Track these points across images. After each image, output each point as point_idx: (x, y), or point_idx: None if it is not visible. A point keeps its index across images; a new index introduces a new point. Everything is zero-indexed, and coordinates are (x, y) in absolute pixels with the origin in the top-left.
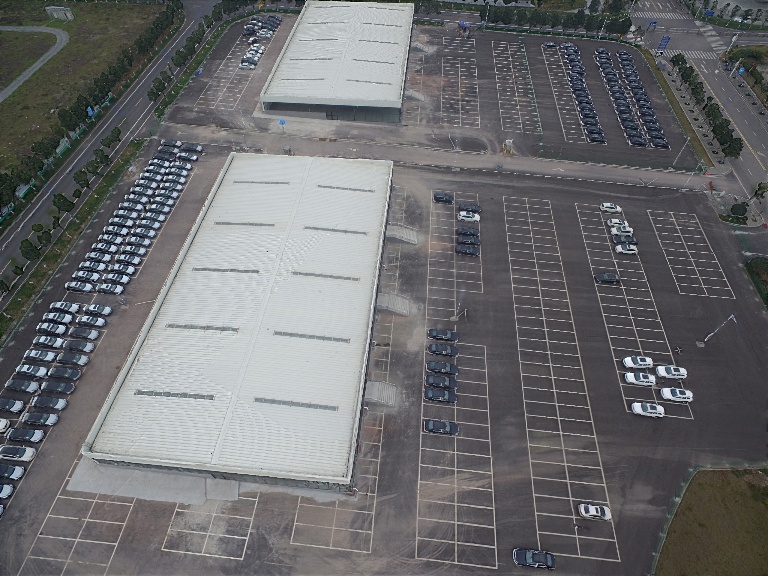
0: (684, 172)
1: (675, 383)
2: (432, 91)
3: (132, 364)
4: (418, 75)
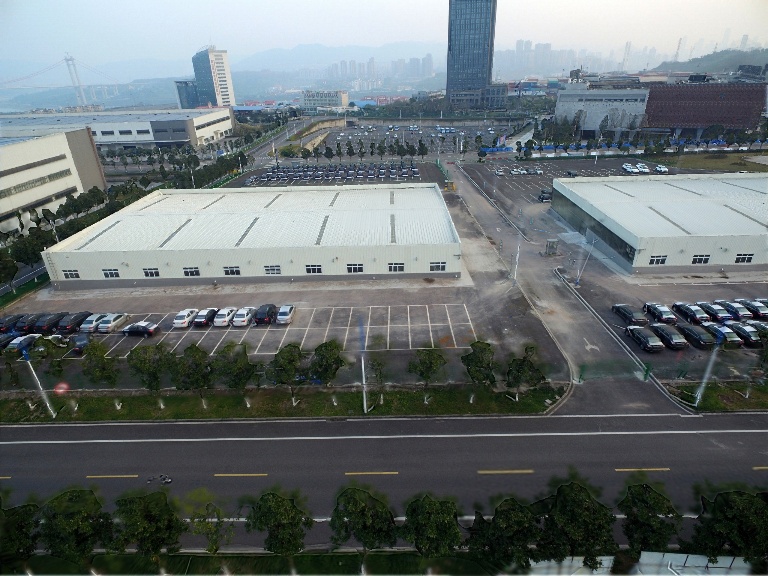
0: None
1: None
2: None
3: None
4: None
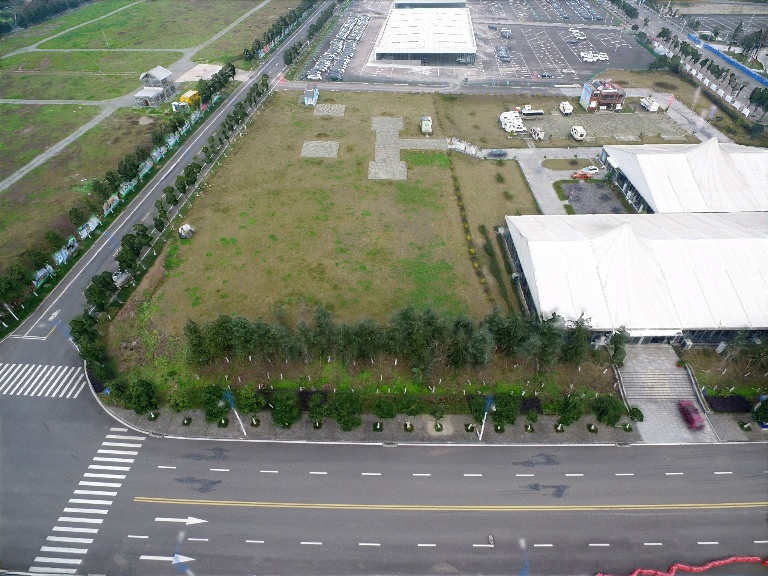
0: (611, 26)
1: None
2: (478, 8)
3: (380, 40)
4: (469, 4)
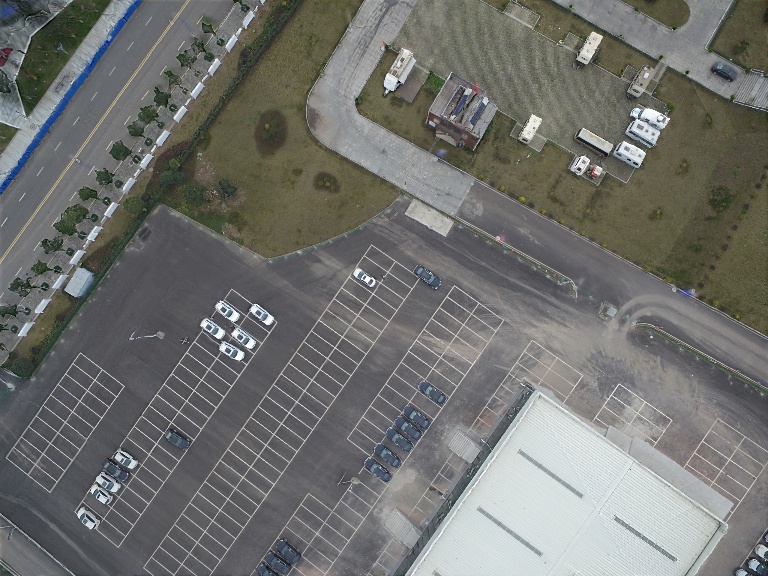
0: None
1: (217, 320)
2: None
3: None
4: None
